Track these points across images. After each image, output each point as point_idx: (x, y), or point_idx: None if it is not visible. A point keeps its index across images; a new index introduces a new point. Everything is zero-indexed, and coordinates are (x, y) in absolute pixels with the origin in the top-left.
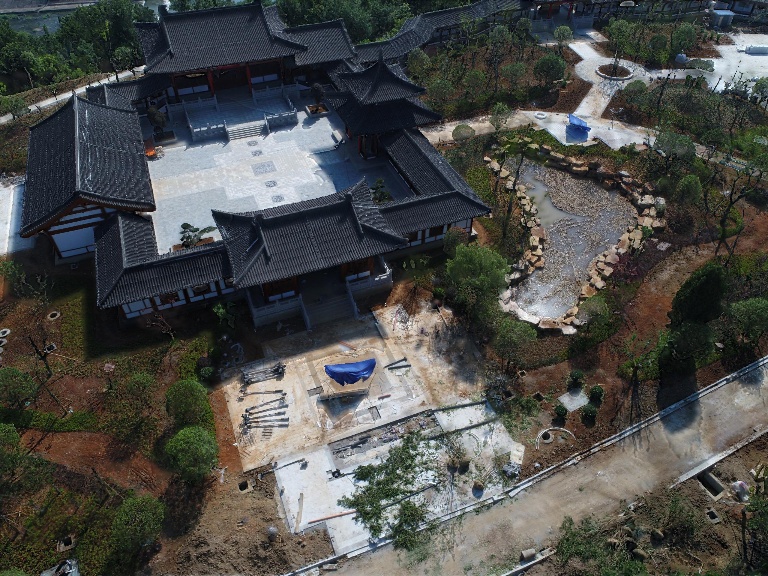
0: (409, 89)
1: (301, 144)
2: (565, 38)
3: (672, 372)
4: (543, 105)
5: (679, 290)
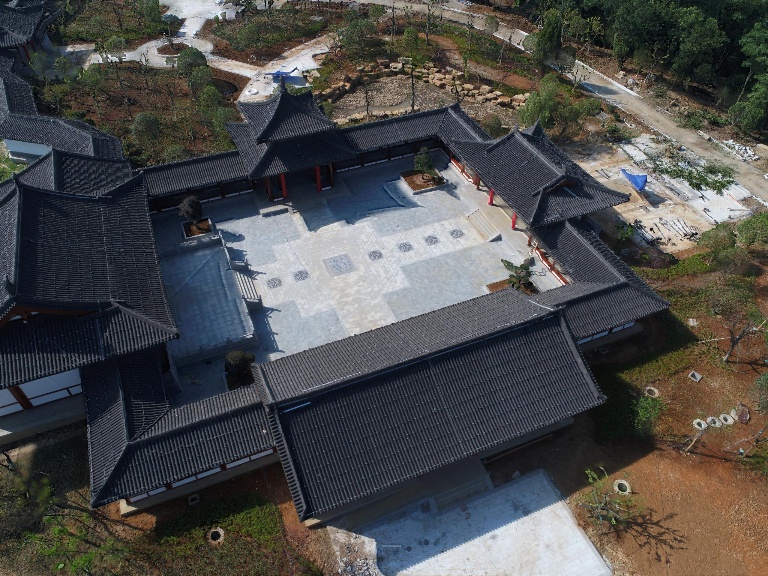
0: (307, 99)
1: (284, 239)
2: (126, 46)
3: (567, 83)
4: (231, 88)
5: (549, 43)
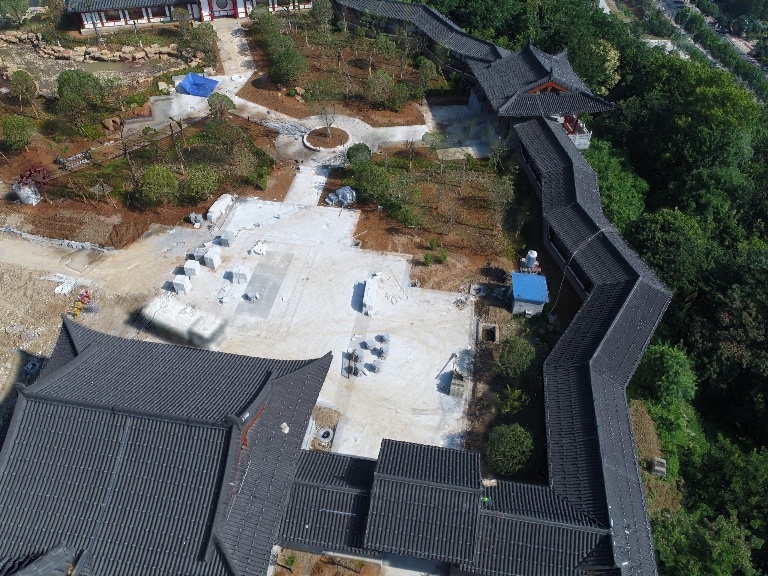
0: None
1: None
2: None
3: None
4: (258, 82)
5: None
